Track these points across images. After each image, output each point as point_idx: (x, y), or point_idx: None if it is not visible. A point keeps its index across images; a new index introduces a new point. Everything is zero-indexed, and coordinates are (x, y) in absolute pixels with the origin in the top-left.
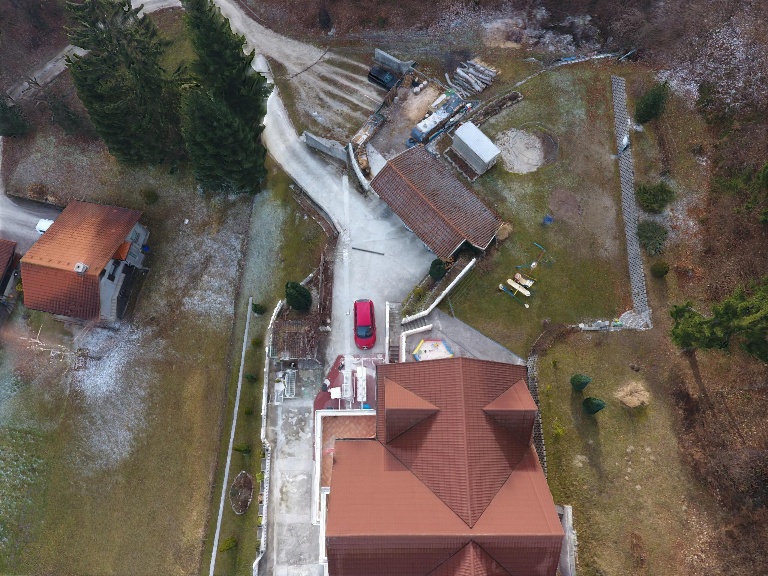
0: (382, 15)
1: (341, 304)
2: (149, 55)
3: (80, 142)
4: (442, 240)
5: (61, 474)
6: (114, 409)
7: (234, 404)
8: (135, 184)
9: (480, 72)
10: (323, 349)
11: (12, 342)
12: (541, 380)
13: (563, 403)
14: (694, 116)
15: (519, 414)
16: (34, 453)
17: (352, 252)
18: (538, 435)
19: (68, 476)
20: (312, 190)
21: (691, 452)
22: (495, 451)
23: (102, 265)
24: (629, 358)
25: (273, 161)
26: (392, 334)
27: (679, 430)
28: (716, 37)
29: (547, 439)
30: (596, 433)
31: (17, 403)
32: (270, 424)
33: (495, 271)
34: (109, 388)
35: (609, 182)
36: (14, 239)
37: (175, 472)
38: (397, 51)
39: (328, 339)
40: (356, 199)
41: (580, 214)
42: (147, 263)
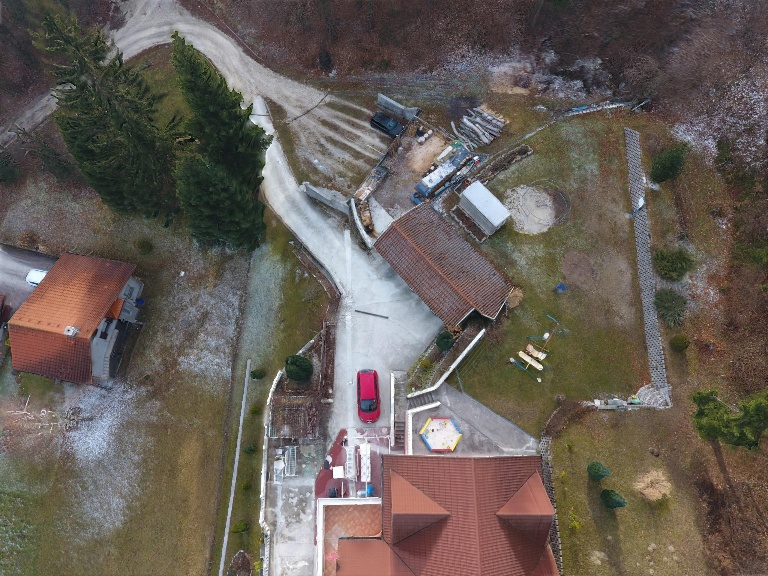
0: (385, 58)
1: (343, 372)
2: (142, 113)
3: (72, 188)
4: (449, 307)
5: (51, 542)
6: (107, 474)
7: (232, 474)
8: (129, 233)
9: (487, 121)
10: (325, 422)
11: (1, 399)
12: (555, 465)
13: (579, 491)
14: (713, 175)
15: (535, 518)
16: (23, 518)
17: (355, 315)
18: (553, 525)
19: (59, 544)
20: (313, 245)
21: (718, 557)
22: (510, 559)
23: (93, 327)
24: (648, 441)
25: (272, 212)
26: (397, 408)
27: (703, 526)
28: (735, 90)
29: (563, 531)
30: (615, 528)
31: (6, 464)
32: (269, 505)
33: (505, 341)
34: (101, 451)
35: (624, 243)
36: (3, 289)
37: (170, 545)
38: (400, 95)
39: (330, 411)
40: (359, 256)
41: (594, 278)
42: (141, 317)
